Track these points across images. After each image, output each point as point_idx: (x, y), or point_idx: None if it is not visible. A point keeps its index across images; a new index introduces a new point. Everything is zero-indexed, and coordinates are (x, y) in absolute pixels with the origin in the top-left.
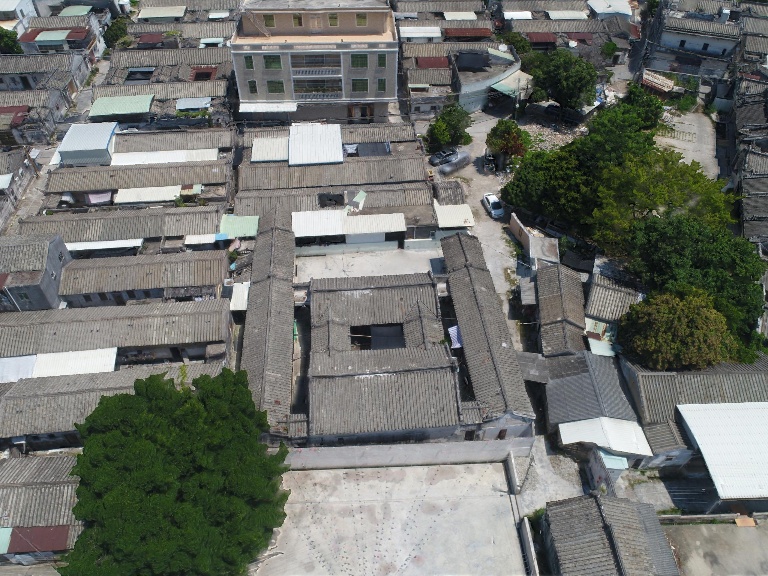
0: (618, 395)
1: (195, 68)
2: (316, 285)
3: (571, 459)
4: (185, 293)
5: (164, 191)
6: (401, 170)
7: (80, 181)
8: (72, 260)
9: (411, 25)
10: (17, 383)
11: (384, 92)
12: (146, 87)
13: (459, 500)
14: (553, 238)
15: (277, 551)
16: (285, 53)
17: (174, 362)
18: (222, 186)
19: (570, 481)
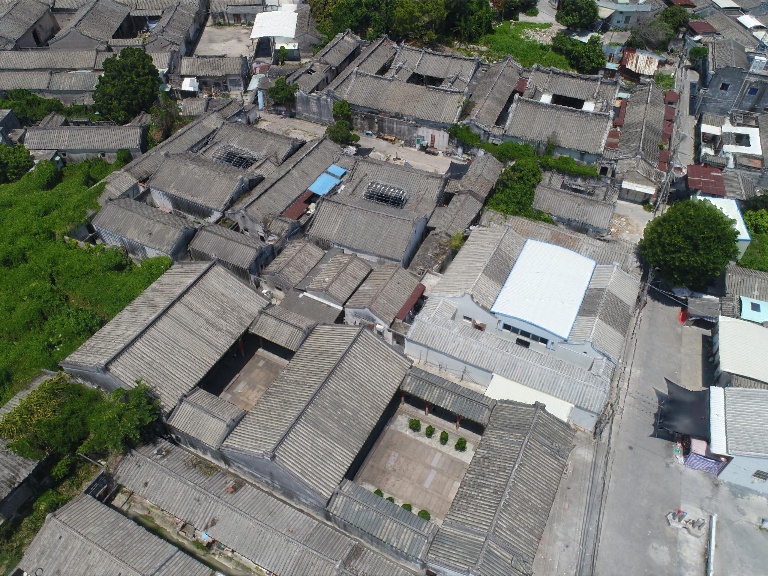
0: None
1: None
2: None
3: None
4: None
5: None
6: None
7: None
8: None
9: None
10: None
11: None
12: None
13: (280, 3)
14: None
15: None
16: None
17: None
18: None
19: None
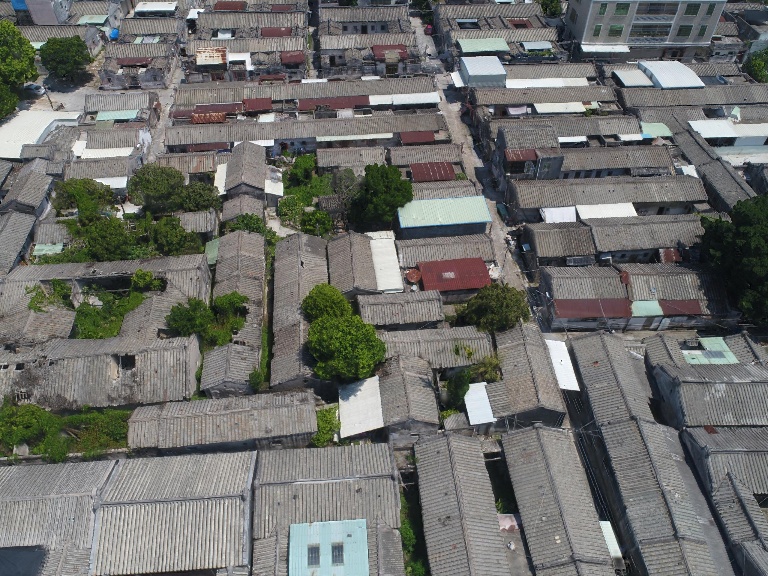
0: None
1: (510, 20)
2: None
3: None
4: (647, 172)
5: (571, 105)
6: (751, 94)
7: (501, 97)
8: None
9: None
10: (585, 220)
11: (702, 37)
12: (492, 32)
13: None
14: None
15: None
16: (635, 1)
17: None
18: (612, 103)
19: None
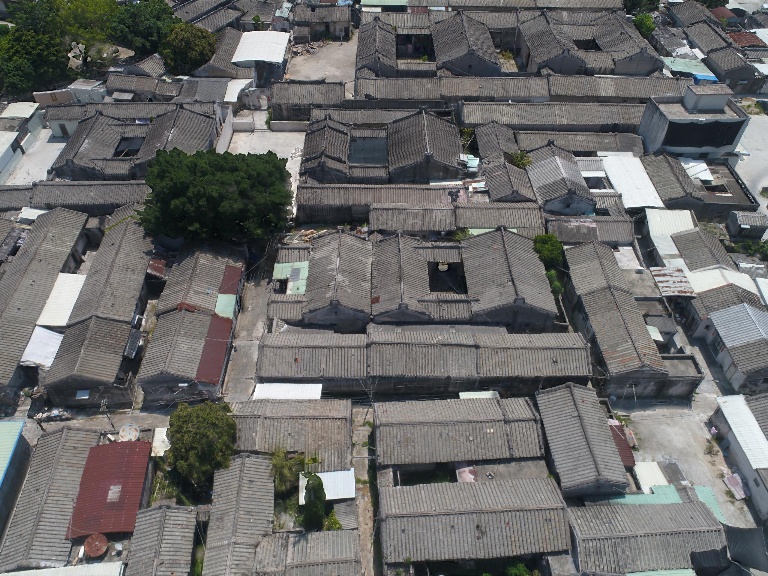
0: (216, 78)
1: None
2: None
3: (241, 111)
4: (9, 246)
5: None
6: None
7: None
8: None
9: None
10: (73, 320)
11: None
12: None
13: (251, 147)
14: (77, 80)
15: None
16: None
17: (79, 268)
18: None
19: (253, 113)
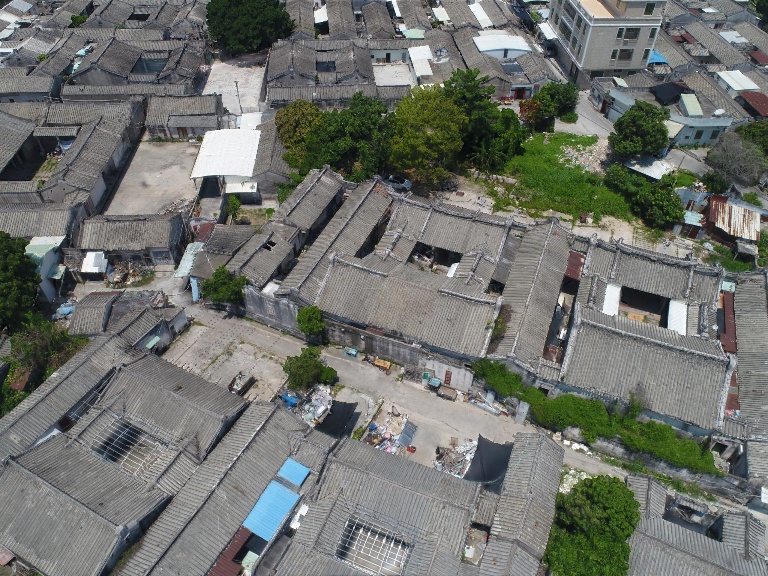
0: None
1: None
2: (361, 49)
3: None
4: None
5: None
6: (482, 73)
7: None
8: (385, 6)
9: (754, 78)
10: (309, 6)
11: None
12: None
13: None
14: None
15: (235, 68)
16: None
17: None
18: None
19: None
